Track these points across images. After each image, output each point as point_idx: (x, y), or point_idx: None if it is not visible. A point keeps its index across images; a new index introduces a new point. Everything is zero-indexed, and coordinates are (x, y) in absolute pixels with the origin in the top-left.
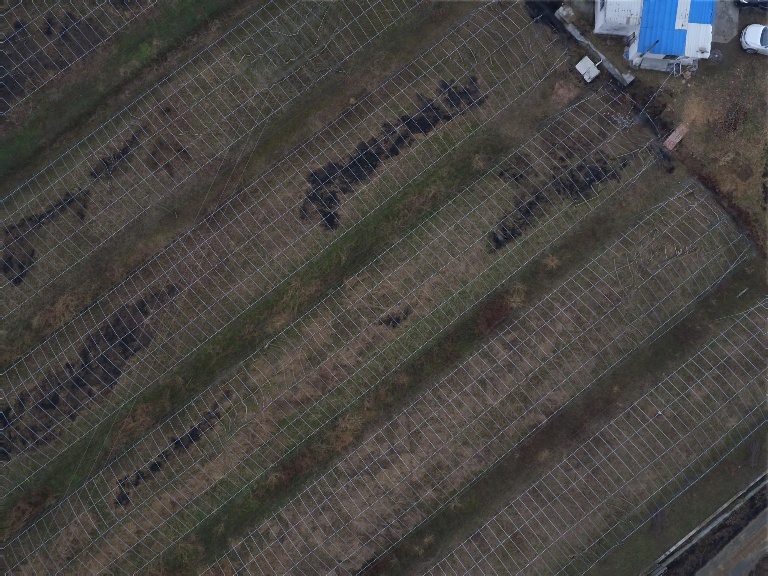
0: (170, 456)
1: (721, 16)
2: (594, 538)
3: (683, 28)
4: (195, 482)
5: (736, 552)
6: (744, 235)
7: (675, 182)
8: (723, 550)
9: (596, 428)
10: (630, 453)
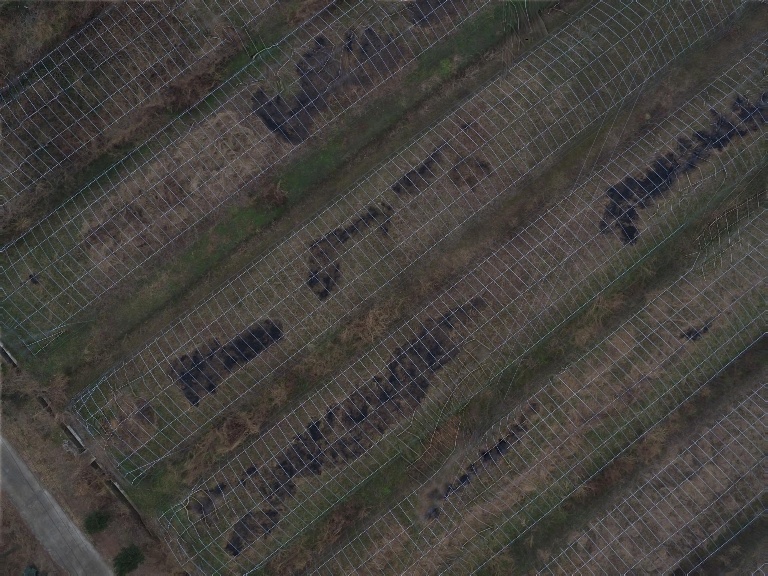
0: (479, 468)
1: None
2: None
3: None
4: (506, 495)
5: None
6: None
7: None
8: None
9: None
10: None
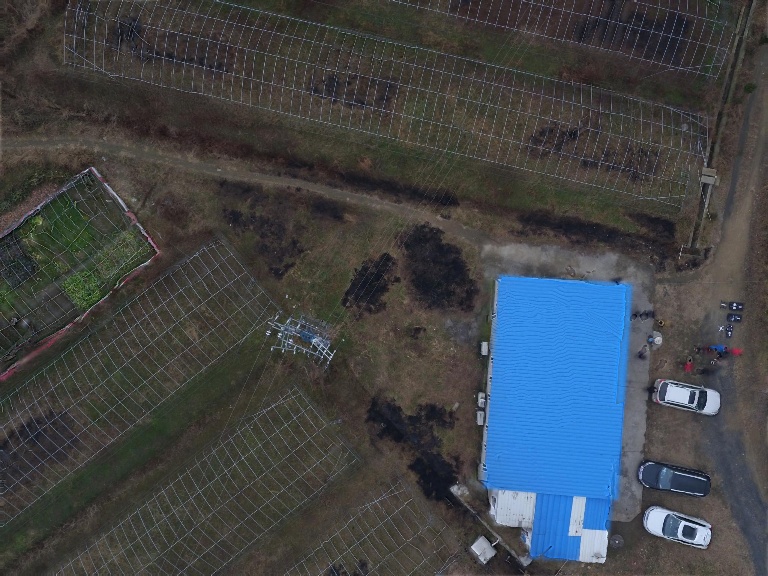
0: None
1: (624, 493)
2: None
3: (577, 534)
4: None
5: None
6: None
7: None
8: None
9: None
10: None
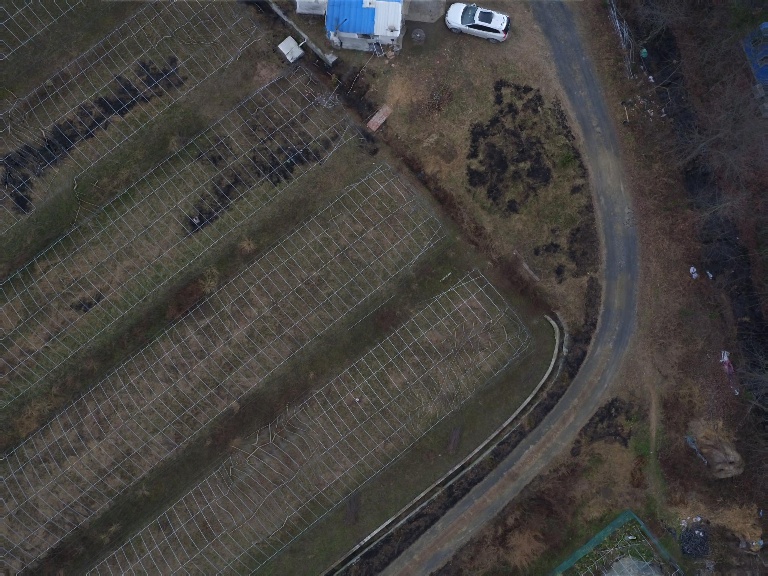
0: None
1: None
2: (278, 524)
3: (371, 6)
4: None
5: (432, 542)
6: (434, 216)
7: (369, 163)
8: (419, 539)
9: (280, 412)
10: (303, 437)
